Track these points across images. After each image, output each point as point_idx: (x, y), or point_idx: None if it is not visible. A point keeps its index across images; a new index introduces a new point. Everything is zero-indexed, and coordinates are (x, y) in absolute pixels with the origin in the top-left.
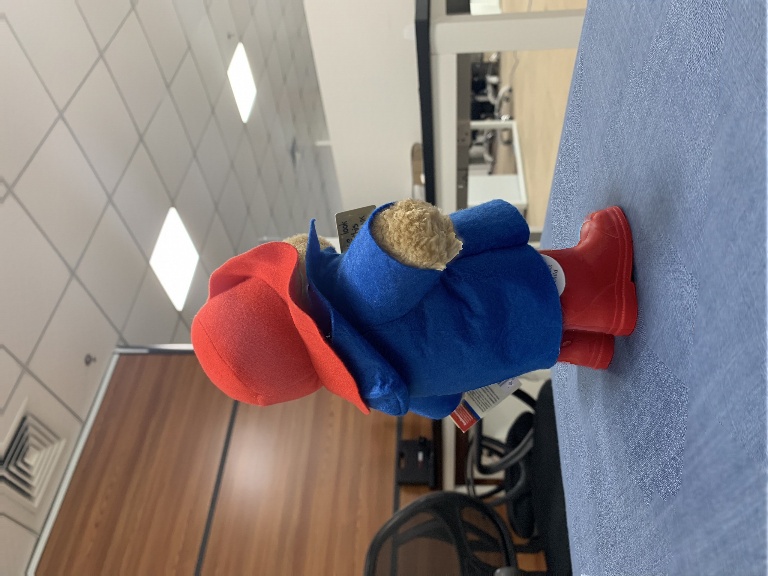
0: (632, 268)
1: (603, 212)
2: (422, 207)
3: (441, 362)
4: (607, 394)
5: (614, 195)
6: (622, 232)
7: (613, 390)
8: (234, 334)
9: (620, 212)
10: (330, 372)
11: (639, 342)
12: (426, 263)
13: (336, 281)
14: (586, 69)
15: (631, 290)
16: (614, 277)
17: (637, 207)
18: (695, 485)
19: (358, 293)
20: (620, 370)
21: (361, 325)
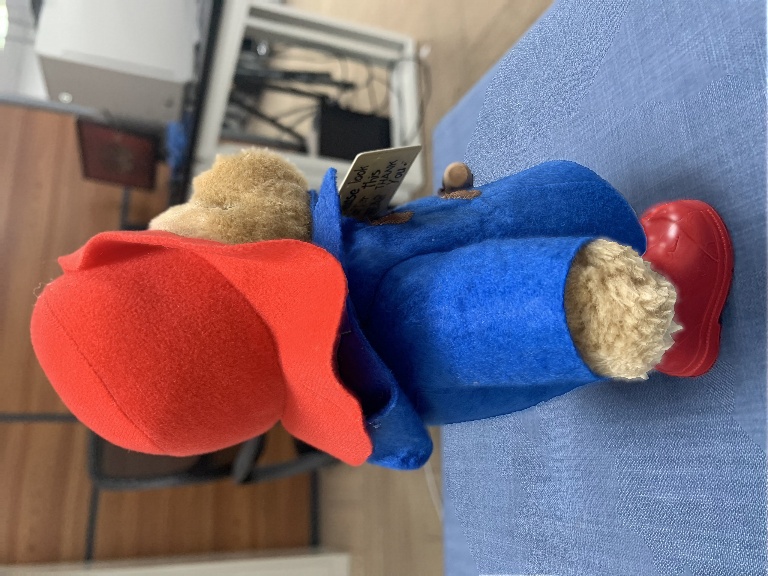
0: (724, 305)
1: (697, 213)
2: (652, 276)
3: (481, 415)
4: (589, 401)
5: (702, 184)
6: (724, 254)
7: (608, 407)
8: (160, 380)
9: (720, 220)
10: (324, 435)
11: (709, 401)
12: None
13: (393, 321)
14: None
15: (716, 334)
16: (702, 314)
17: None
18: None
19: (448, 364)
20: (638, 398)
21: (414, 391)
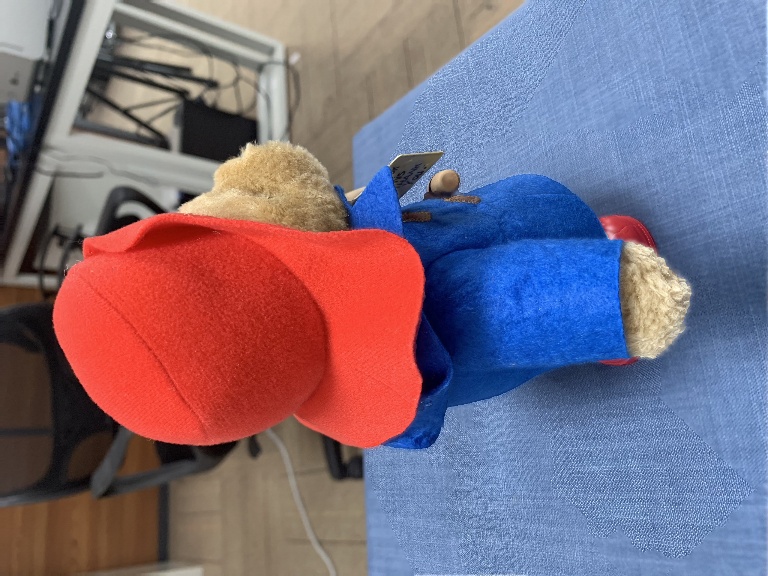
0: None
1: (632, 227)
2: None
3: (474, 399)
4: (524, 390)
5: (632, 203)
6: None
7: (543, 395)
8: (225, 363)
9: (649, 234)
10: (353, 418)
11: (638, 385)
12: (651, 356)
13: (443, 309)
14: (599, 4)
15: None
16: None
17: (694, 250)
18: (727, 572)
19: (494, 348)
20: (572, 386)
21: None
